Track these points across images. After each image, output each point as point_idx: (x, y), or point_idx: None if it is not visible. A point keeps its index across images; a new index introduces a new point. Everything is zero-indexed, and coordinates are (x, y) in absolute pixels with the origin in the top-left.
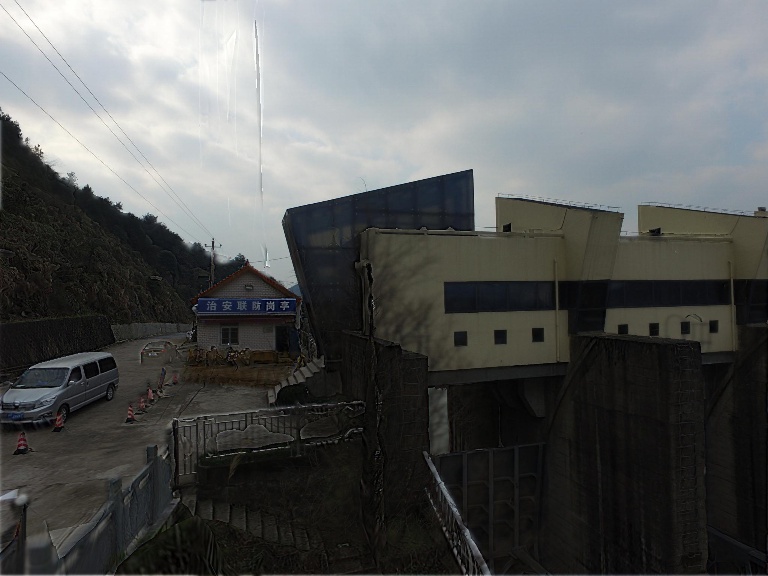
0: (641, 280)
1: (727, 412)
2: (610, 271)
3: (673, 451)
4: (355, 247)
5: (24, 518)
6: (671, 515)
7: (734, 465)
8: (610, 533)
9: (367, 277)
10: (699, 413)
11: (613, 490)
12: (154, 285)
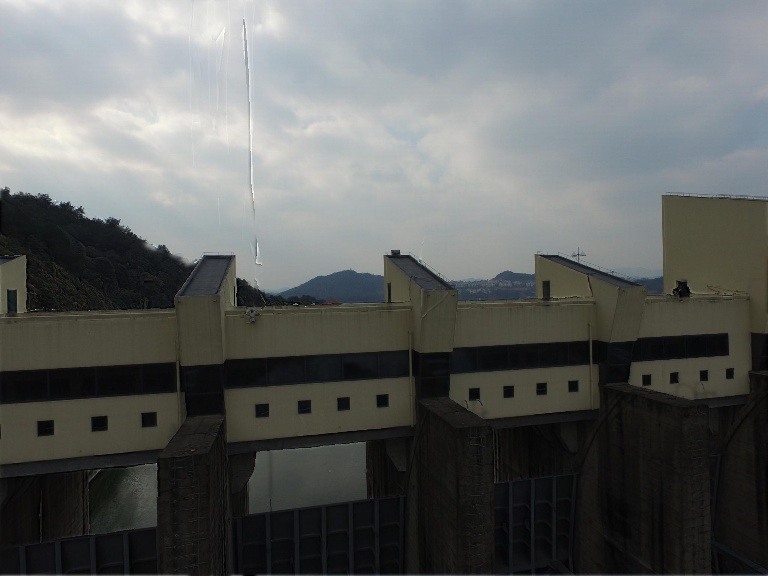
0: (25, 370)
1: None
2: None
3: None
4: None
5: None
6: None
7: None
8: None
9: None
10: None
11: None
12: (44, 298)
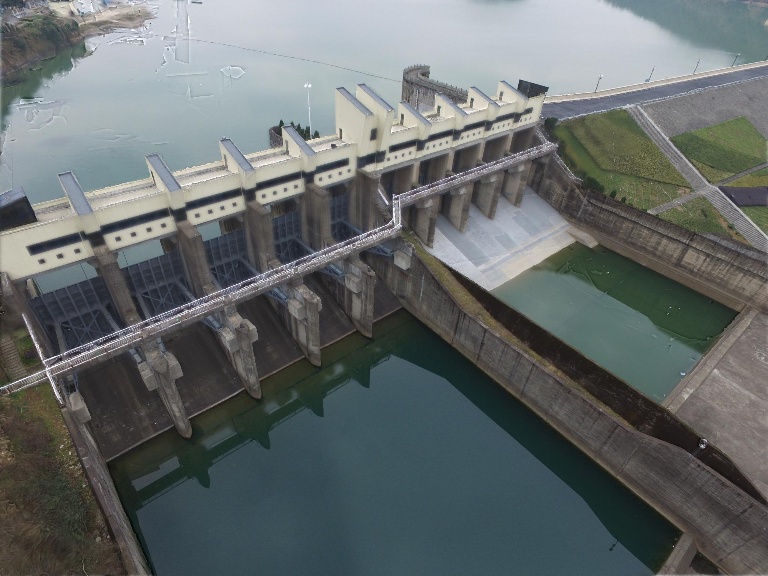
0: None
1: None
2: None
3: (114, 290)
4: None
5: None
6: (119, 303)
7: None
8: None
9: None
10: (121, 279)
11: None
12: None
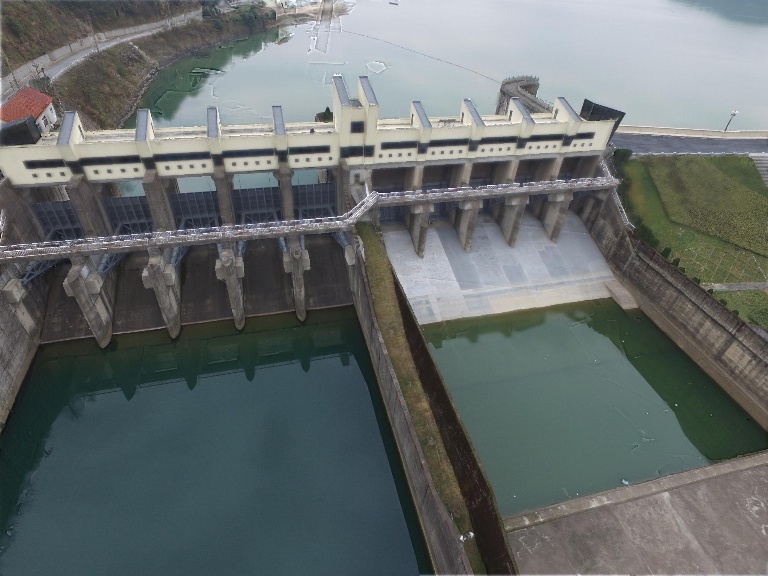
0: None
1: None
2: None
3: (76, 210)
4: None
5: None
6: None
7: None
8: None
9: None
10: None
11: None
12: (13, 26)
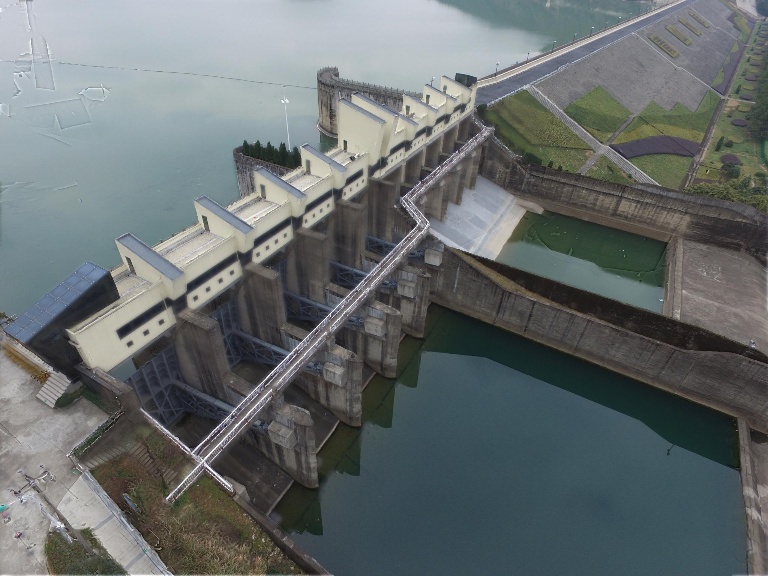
0: (199, 276)
1: (243, 294)
2: (185, 290)
3: (215, 354)
4: (65, 335)
5: (125, 495)
6: (218, 368)
7: (247, 310)
8: (203, 371)
9: (82, 350)
10: None
11: (201, 361)
12: None
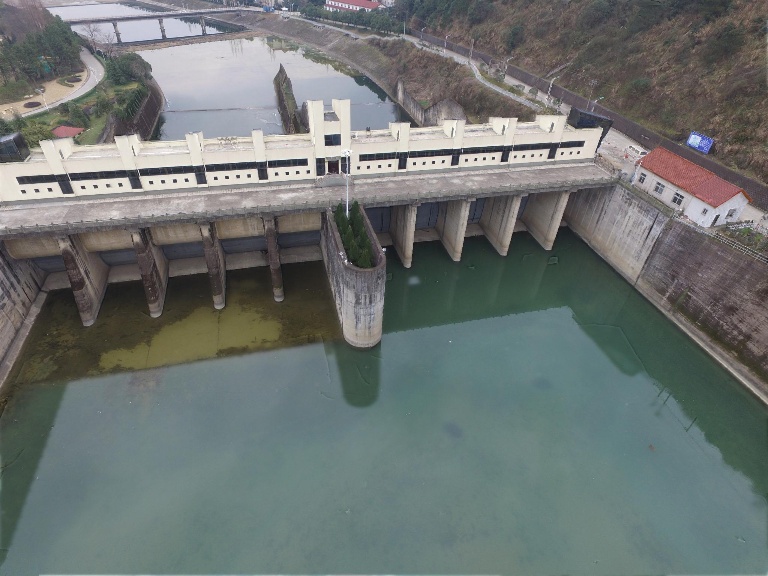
0: None
1: None
2: None
3: None
4: None
5: None
6: None
7: None
8: None
9: None
10: None
11: None
12: None
